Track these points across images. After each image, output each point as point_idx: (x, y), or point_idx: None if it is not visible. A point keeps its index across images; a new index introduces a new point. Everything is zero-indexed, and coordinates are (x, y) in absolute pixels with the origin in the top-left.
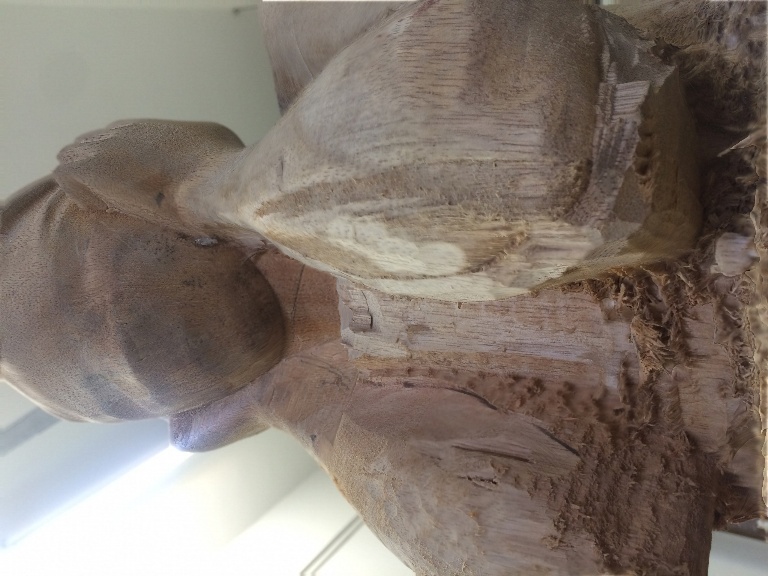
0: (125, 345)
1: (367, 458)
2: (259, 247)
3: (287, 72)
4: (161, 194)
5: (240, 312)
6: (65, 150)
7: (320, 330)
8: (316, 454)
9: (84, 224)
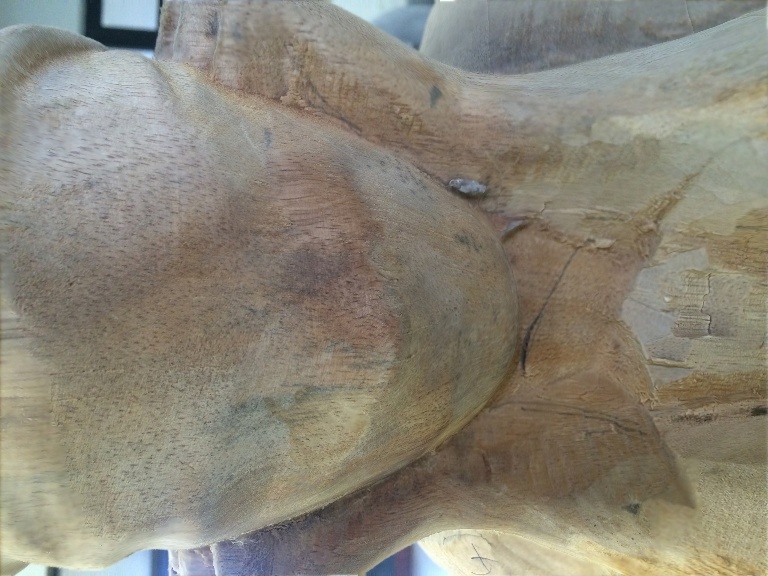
0: (400, 319)
1: None
2: (531, 214)
3: (594, 3)
4: (436, 88)
5: (512, 304)
6: None
7: (558, 359)
8: (645, 535)
9: (244, 104)
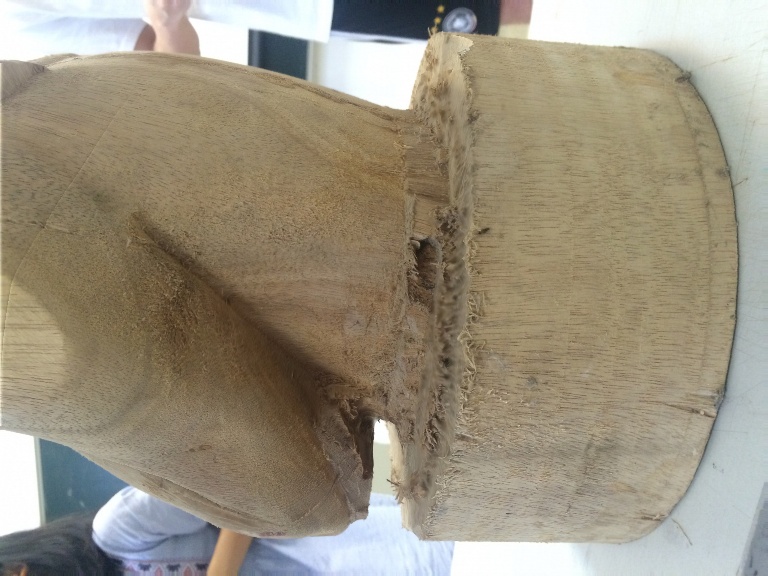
0: None
1: None
2: None
3: None
4: None
5: None
6: None
7: None
8: None
9: None
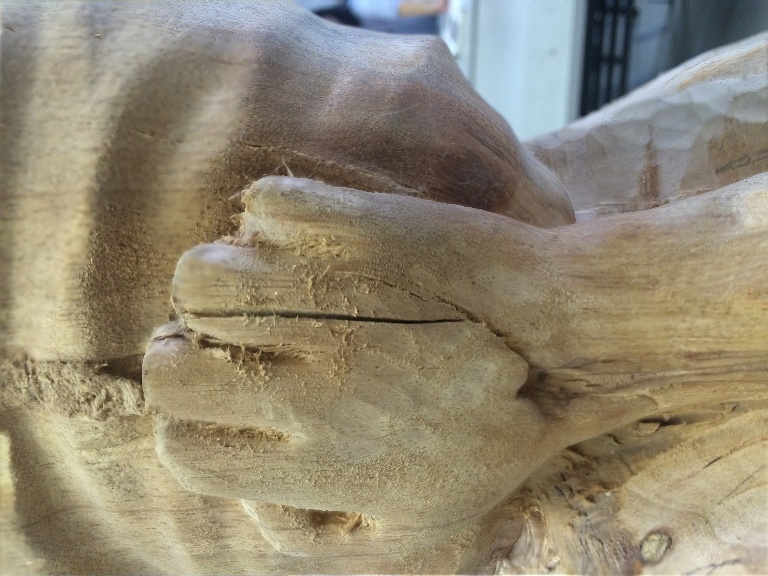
0: None
1: None
2: None
3: None
4: None
5: None
6: None
7: None
8: None
9: None
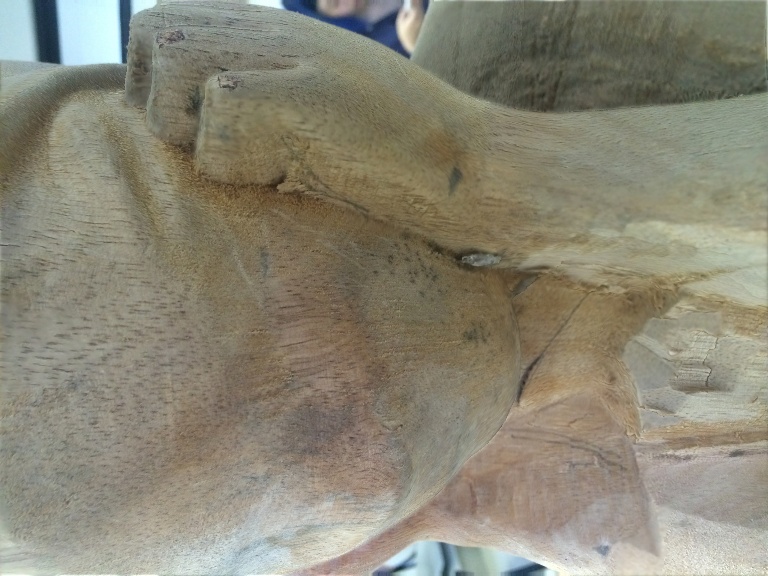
0: (402, 470)
1: (767, 565)
2: (545, 270)
3: (655, 4)
4: (457, 170)
5: (515, 377)
6: (180, 33)
7: (553, 389)
8: (609, 573)
9: (236, 212)
